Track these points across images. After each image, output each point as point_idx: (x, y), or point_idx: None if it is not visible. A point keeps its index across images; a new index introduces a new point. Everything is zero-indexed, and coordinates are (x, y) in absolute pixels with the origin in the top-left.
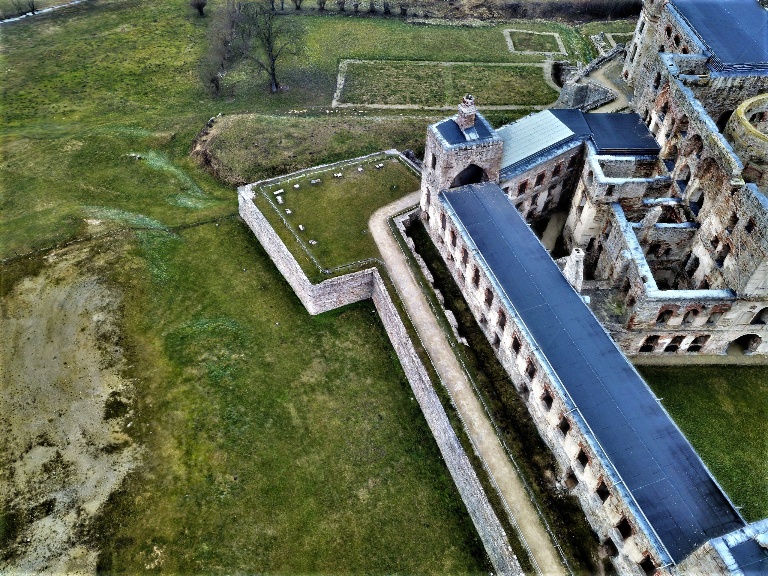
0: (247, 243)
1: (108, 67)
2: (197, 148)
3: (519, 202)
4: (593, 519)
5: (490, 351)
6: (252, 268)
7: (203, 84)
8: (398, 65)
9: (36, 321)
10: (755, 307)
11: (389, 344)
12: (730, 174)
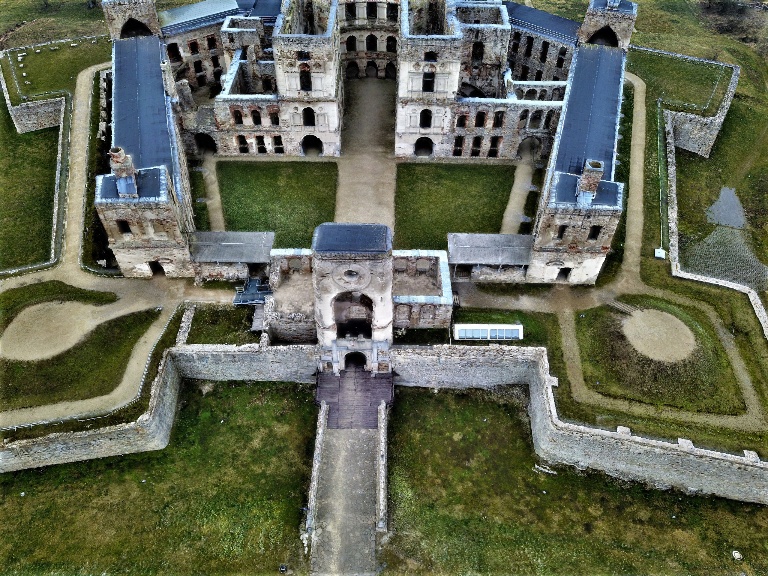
0: None
1: None
2: (0, 40)
3: (197, 60)
4: None
5: None
6: None
7: (38, 3)
8: None
9: None
10: (297, 108)
11: None
12: None
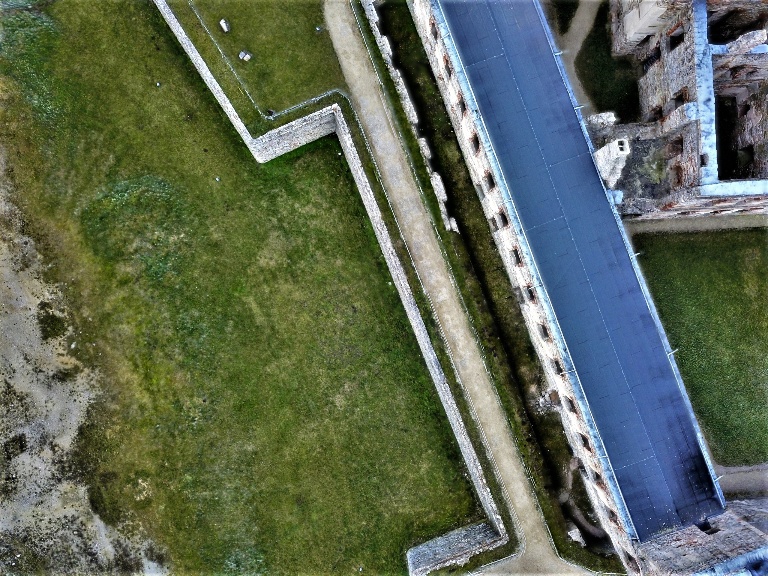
0: (152, 29)
1: None
2: None
3: None
4: (571, 439)
5: (485, 227)
6: (168, 80)
7: None
8: None
9: None
10: None
11: (361, 206)
12: None
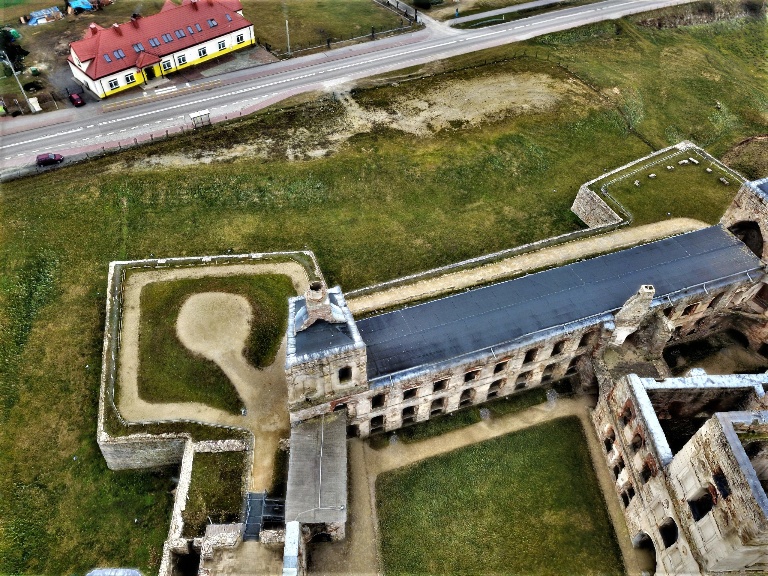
0: None
1: None
2: (759, 138)
3: None
4: None
5: None
6: None
7: None
8: None
9: (515, 86)
10: None
11: None
12: None
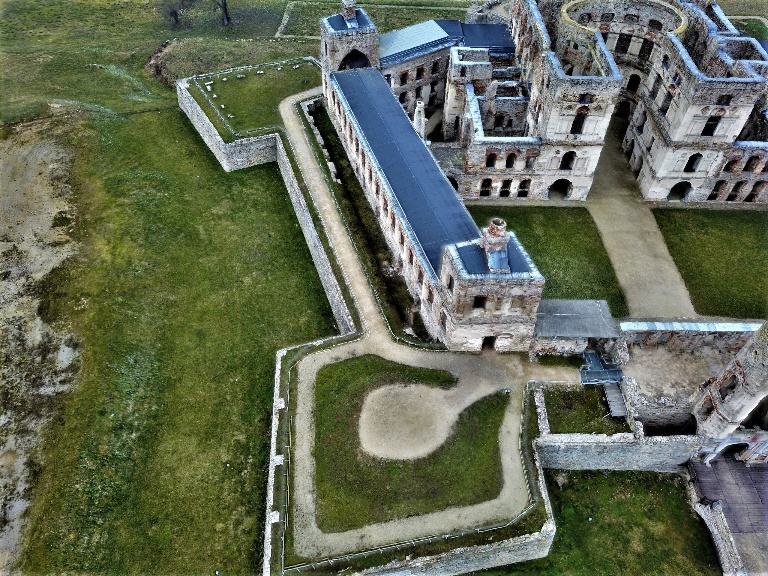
0: (182, 125)
1: (81, 3)
2: (151, 62)
3: (403, 91)
4: (410, 287)
5: (361, 191)
6: (184, 141)
7: (164, 18)
8: (339, 6)
9: (3, 168)
10: (559, 152)
11: (285, 191)
12: (542, 49)
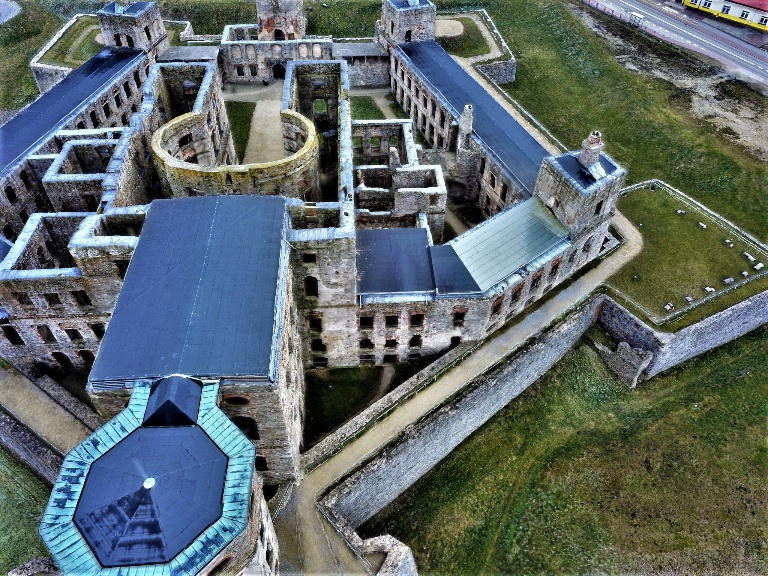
0: None
1: None
2: None
3: None
4: None
5: None
6: None
7: None
8: None
9: None
10: None
11: None
12: None
